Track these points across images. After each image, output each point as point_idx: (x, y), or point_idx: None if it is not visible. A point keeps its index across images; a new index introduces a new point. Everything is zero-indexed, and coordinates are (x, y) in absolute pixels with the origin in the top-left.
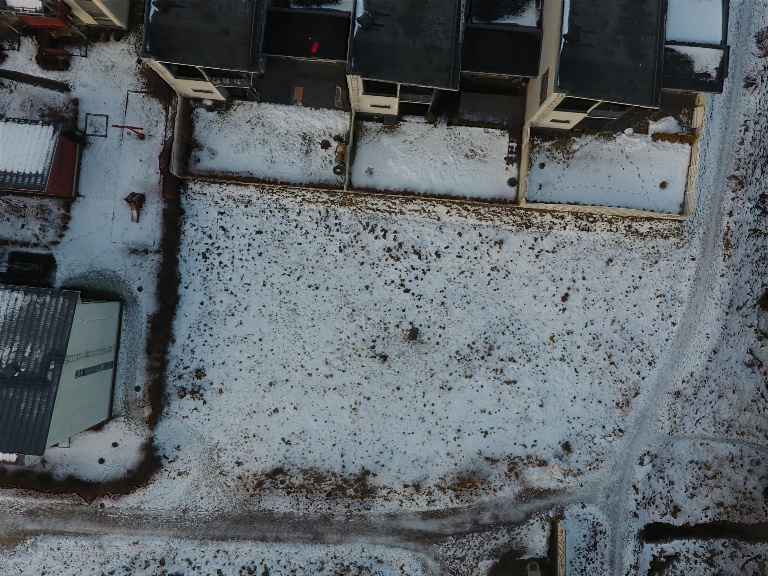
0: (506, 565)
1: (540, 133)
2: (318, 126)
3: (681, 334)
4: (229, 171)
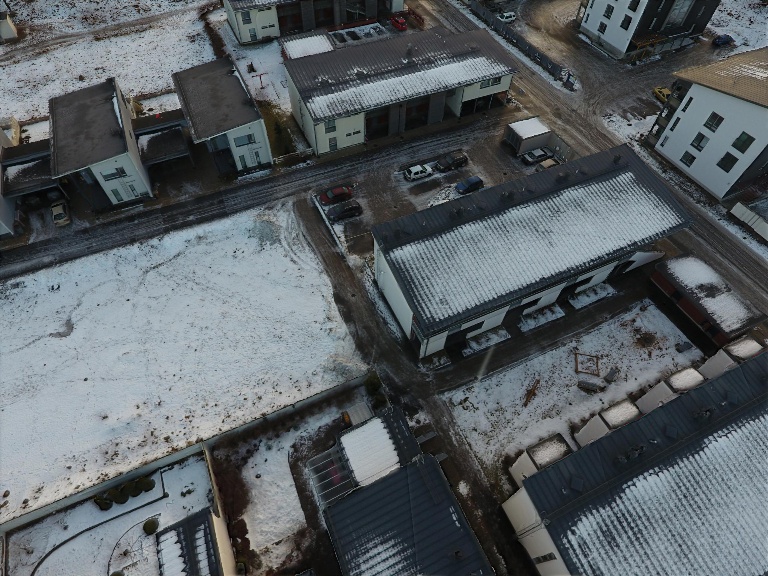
0: (17, 40)
1: None
2: None
3: None
4: None
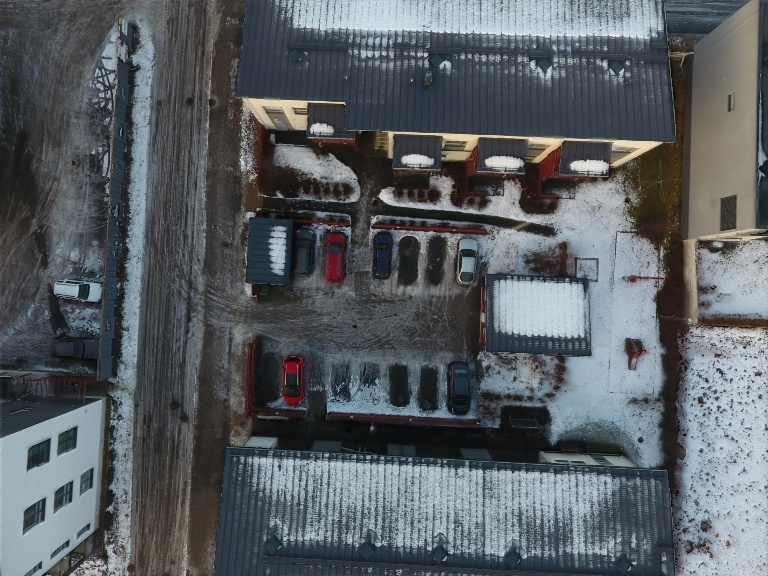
0: None
1: None
2: None
3: None
4: (736, 314)
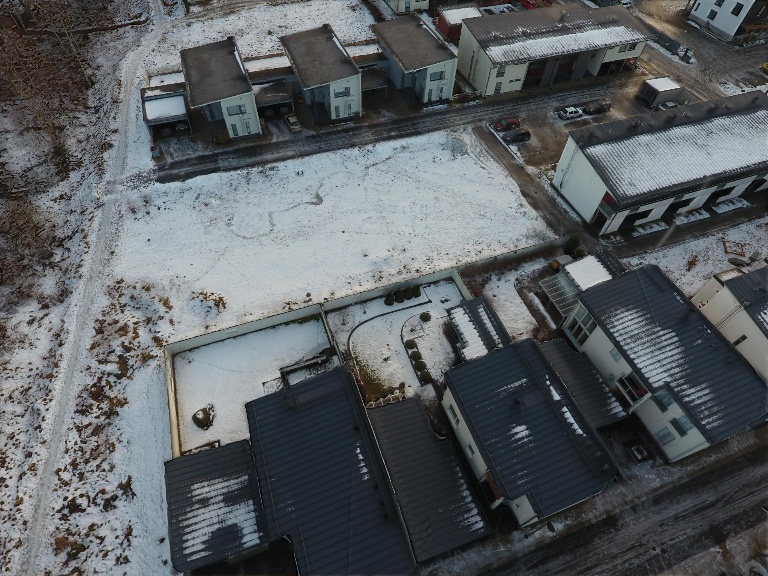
0: None
1: None
2: None
3: None
4: None
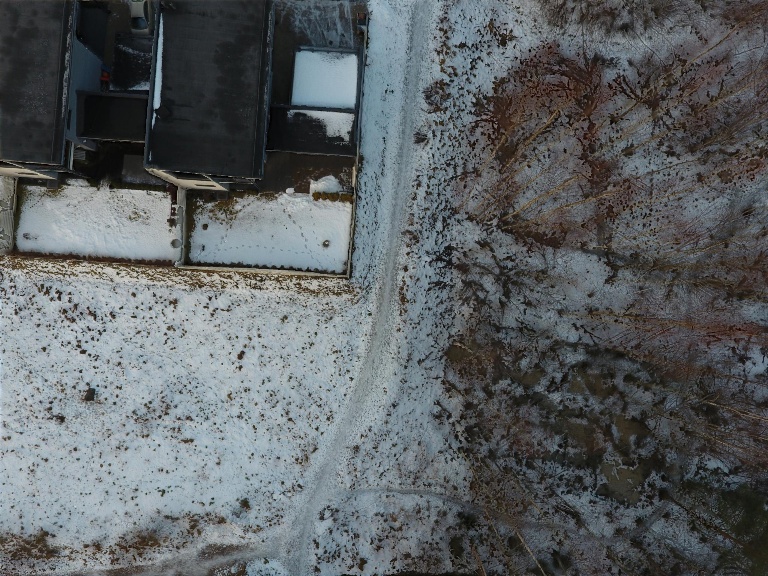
0: None
1: (202, 194)
2: None
3: (358, 389)
4: None
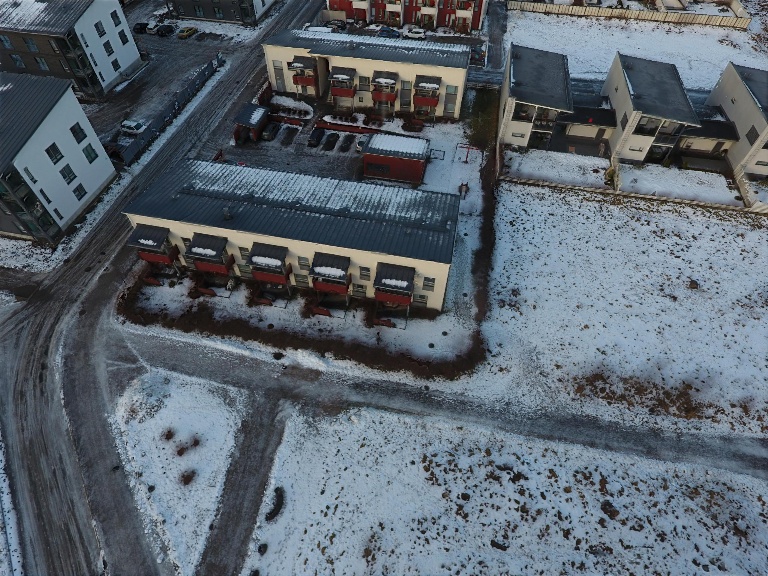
0: None
1: (746, 177)
2: (589, 163)
3: None
4: None
